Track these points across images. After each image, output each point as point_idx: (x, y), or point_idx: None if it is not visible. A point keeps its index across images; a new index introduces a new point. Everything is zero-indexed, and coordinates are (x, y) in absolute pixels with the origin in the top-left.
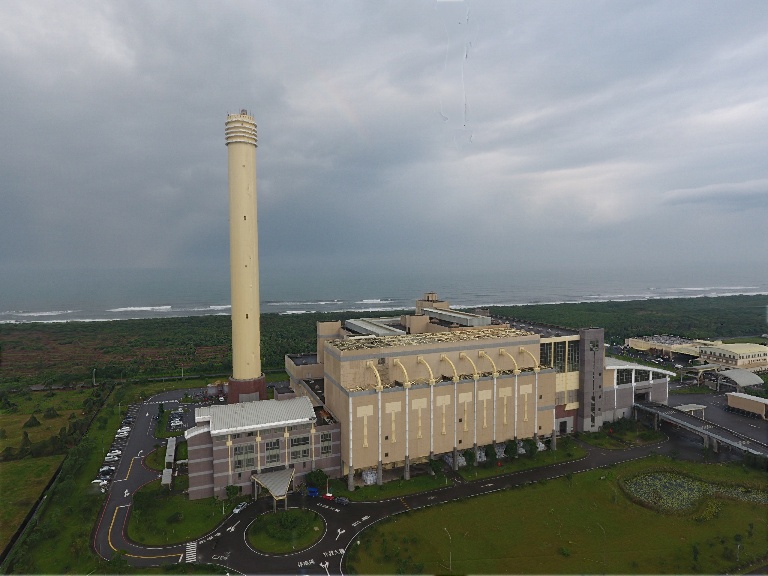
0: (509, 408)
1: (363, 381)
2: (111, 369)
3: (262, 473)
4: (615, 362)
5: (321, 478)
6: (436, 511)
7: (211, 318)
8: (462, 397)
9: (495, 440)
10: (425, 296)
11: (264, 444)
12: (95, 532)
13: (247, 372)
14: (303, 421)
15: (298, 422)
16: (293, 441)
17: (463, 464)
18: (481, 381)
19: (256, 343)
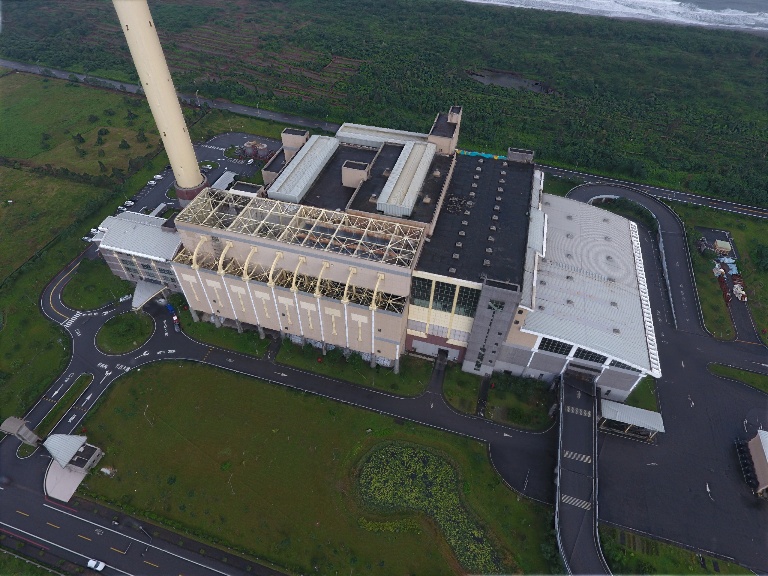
0: (339, 325)
1: (202, 249)
2: (220, 87)
3: (144, 281)
4: (566, 323)
5: (176, 303)
6: (212, 375)
7: (399, 0)
8: (282, 299)
9: (323, 341)
10: None
11: (140, 264)
12: (56, 276)
13: (181, 181)
14: (160, 260)
15: (157, 260)
16: (160, 269)
17: (296, 342)
18: (302, 294)
19: (182, 158)
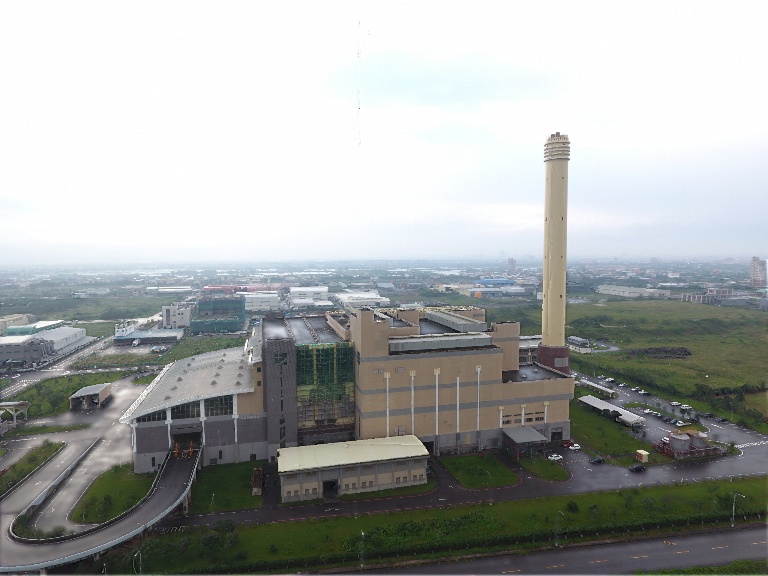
0: None
1: None
2: None
3: None
4: (229, 351)
5: None
6: None
7: None
8: None
9: None
10: (373, 314)
11: None
12: None
13: None
14: None
15: None
16: None
17: None
18: None
19: None
